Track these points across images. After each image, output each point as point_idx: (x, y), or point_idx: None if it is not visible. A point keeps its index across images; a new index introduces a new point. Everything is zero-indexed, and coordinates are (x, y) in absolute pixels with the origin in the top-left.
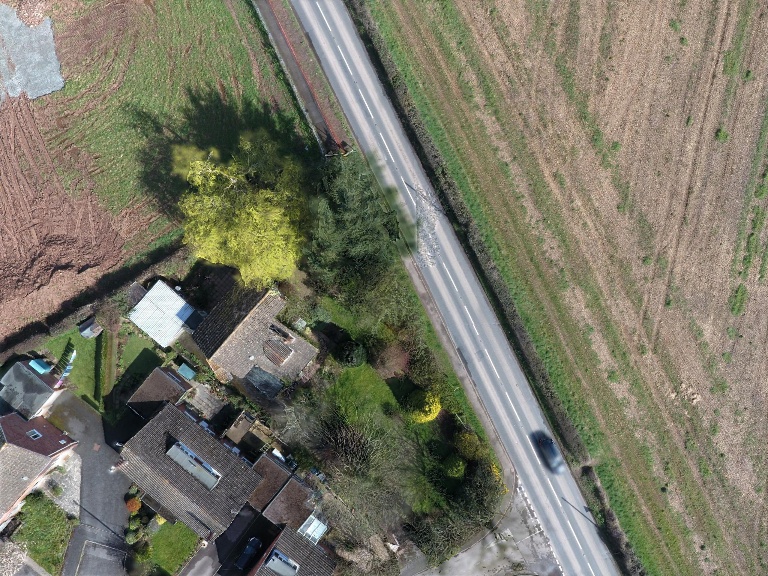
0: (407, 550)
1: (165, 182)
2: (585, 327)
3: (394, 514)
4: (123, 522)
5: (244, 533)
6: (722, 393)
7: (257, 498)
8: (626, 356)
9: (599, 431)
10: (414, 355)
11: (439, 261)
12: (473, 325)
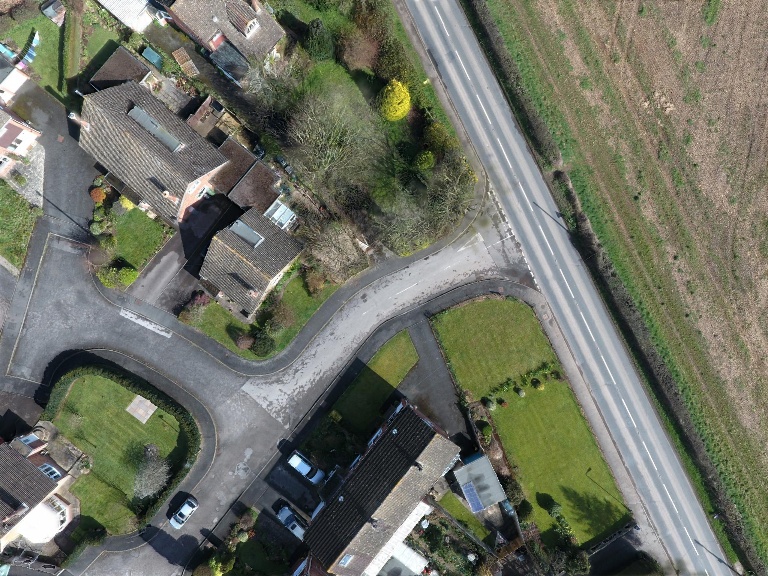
0: (376, 250)
1: None
2: (557, 33)
3: (363, 214)
4: (87, 214)
5: (211, 229)
6: (695, 102)
7: (222, 181)
8: (598, 63)
9: (571, 138)
10: (383, 46)
11: None
12: (443, 26)
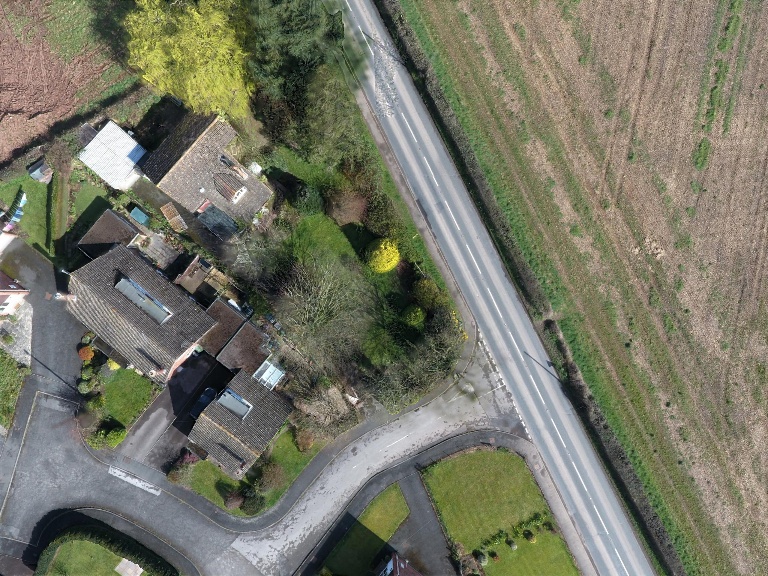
0: (366, 403)
1: (118, 30)
2: (547, 180)
3: (353, 367)
4: (75, 372)
5: (199, 385)
6: (686, 248)
7: (211, 343)
8: (589, 210)
9: (562, 285)
10: (372, 202)
11: (398, 111)
12: (433, 176)
